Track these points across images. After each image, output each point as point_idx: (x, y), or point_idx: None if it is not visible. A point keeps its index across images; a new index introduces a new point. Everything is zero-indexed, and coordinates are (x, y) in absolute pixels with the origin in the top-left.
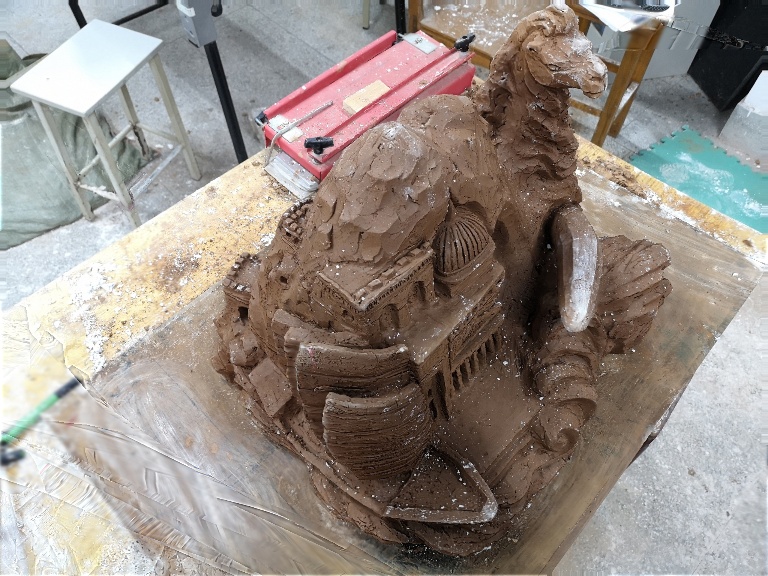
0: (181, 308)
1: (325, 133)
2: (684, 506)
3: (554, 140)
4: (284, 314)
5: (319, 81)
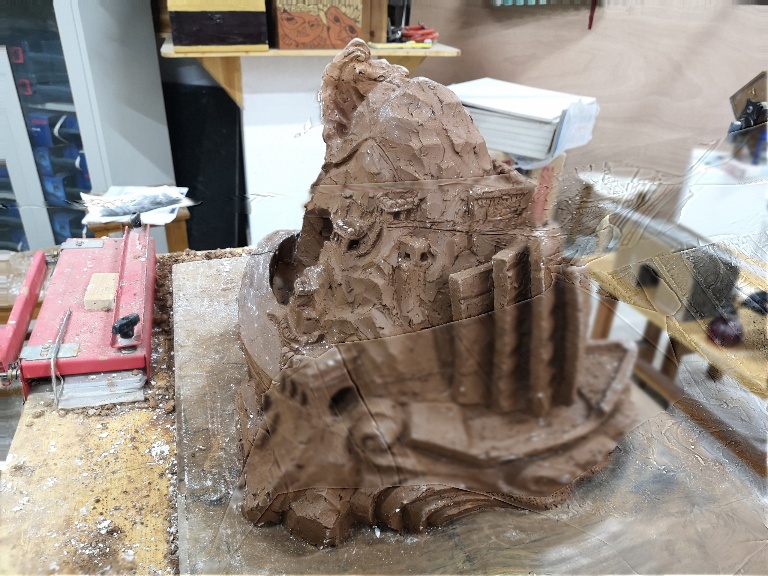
0: (167, 575)
1: (100, 332)
2: None
3: None
4: (459, 273)
5: (20, 311)
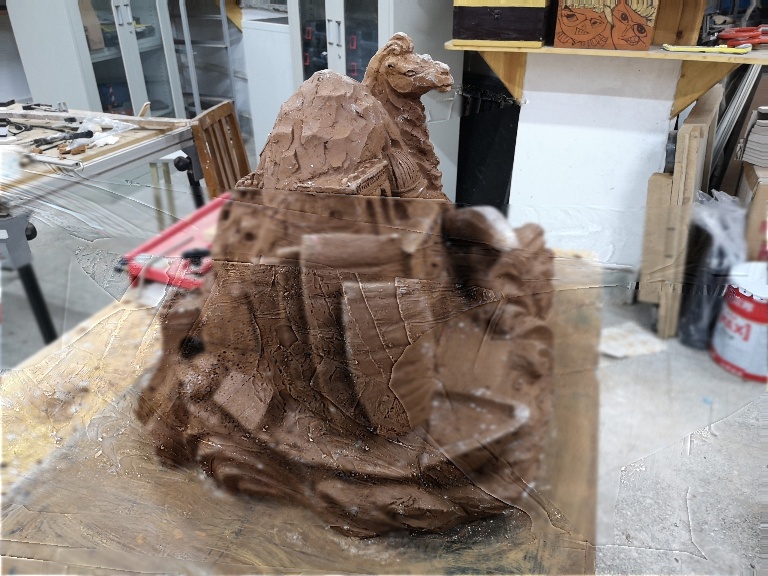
0: None
1: None
2: (639, 570)
3: (423, 148)
4: None
5: None
